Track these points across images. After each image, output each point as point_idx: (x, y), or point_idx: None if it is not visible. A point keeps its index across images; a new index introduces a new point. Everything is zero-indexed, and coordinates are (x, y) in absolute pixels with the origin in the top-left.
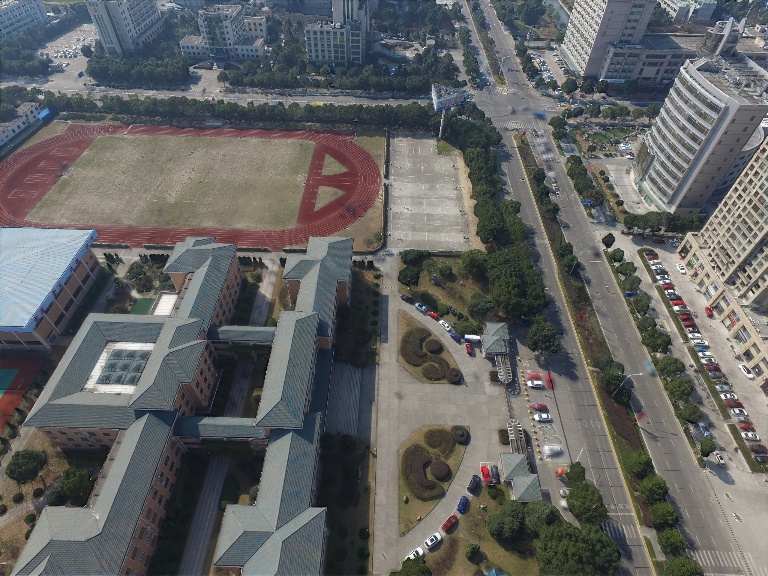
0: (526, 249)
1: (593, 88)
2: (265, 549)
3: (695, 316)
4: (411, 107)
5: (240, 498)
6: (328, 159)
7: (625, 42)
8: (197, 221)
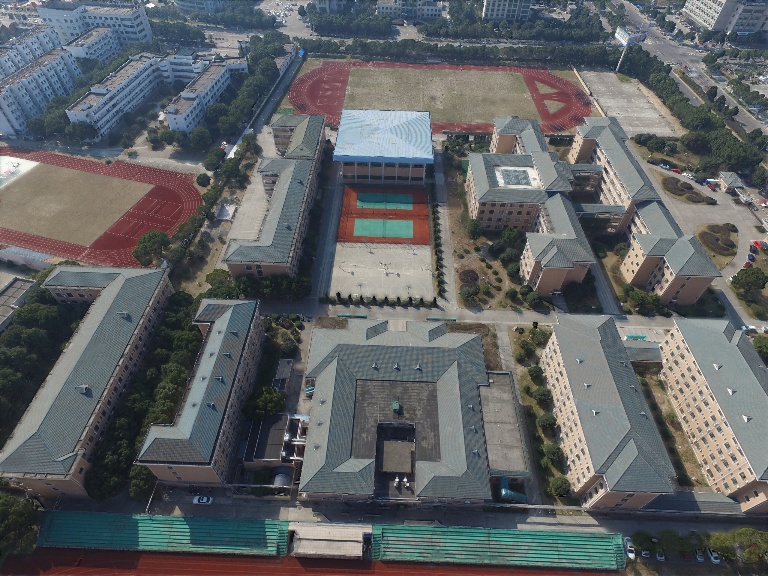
0: None
1: (724, 38)
2: (677, 246)
3: None
4: (594, 47)
5: (607, 253)
6: (539, 84)
7: (751, 1)
8: (469, 119)
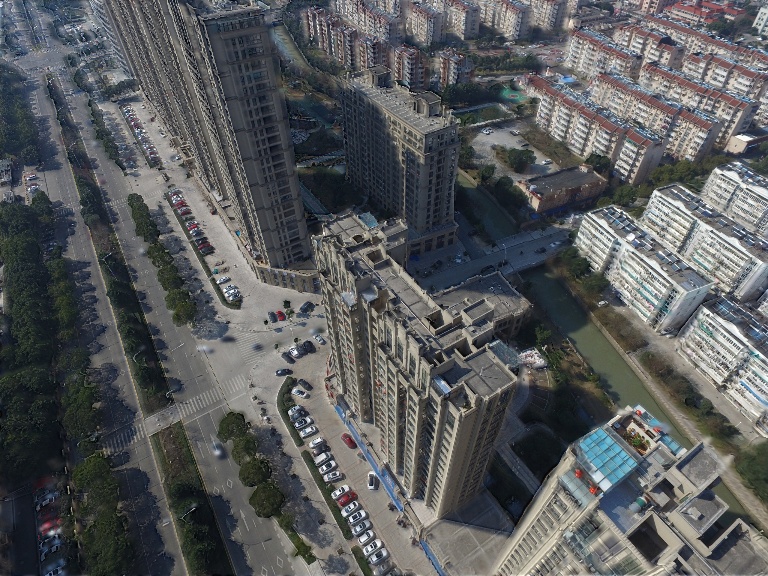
0: (27, 121)
1: None
2: None
3: (143, 123)
4: None
5: None
6: None
7: None
8: None
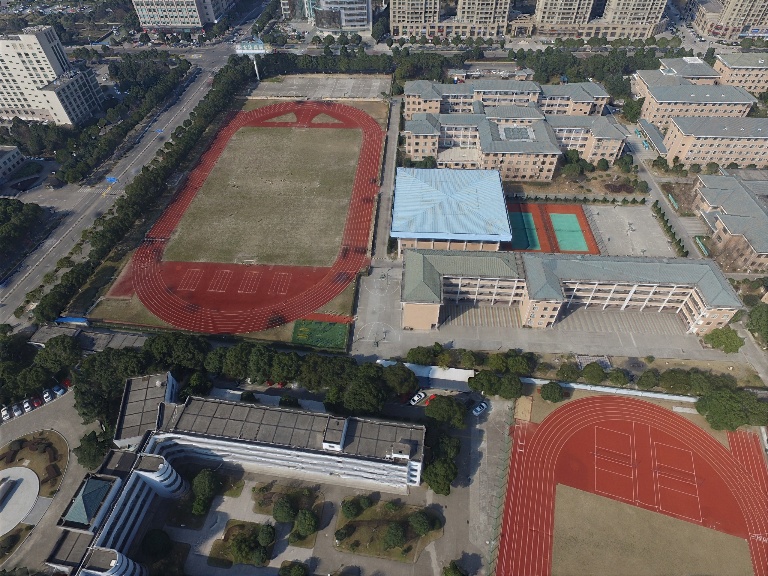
0: None
1: None
2: (587, 88)
3: None
4: (231, 73)
5: None
6: (273, 120)
7: None
8: (349, 168)
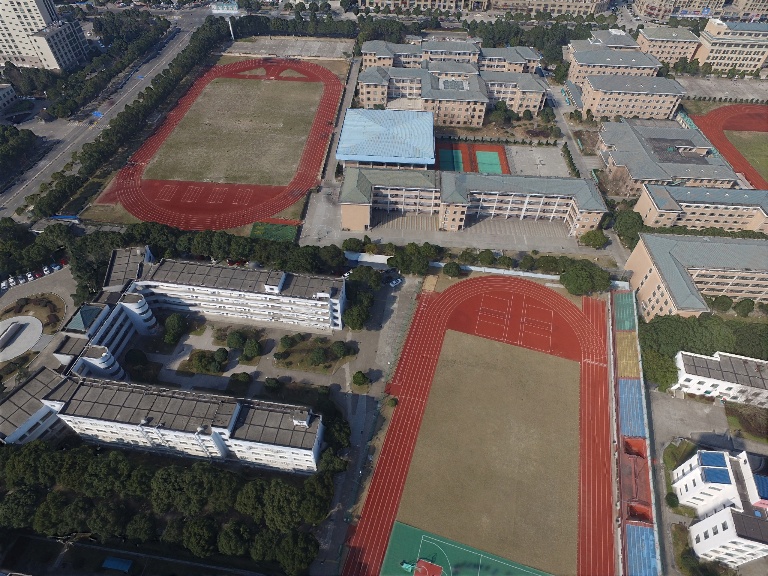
0: None
1: None
2: (520, 51)
3: None
4: (207, 31)
5: None
6: (245, 73)
7: None
8: (309, 113)
